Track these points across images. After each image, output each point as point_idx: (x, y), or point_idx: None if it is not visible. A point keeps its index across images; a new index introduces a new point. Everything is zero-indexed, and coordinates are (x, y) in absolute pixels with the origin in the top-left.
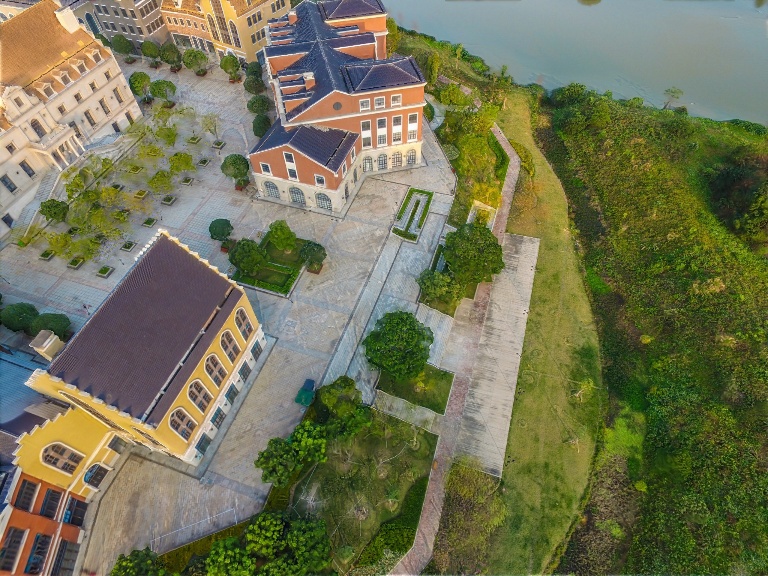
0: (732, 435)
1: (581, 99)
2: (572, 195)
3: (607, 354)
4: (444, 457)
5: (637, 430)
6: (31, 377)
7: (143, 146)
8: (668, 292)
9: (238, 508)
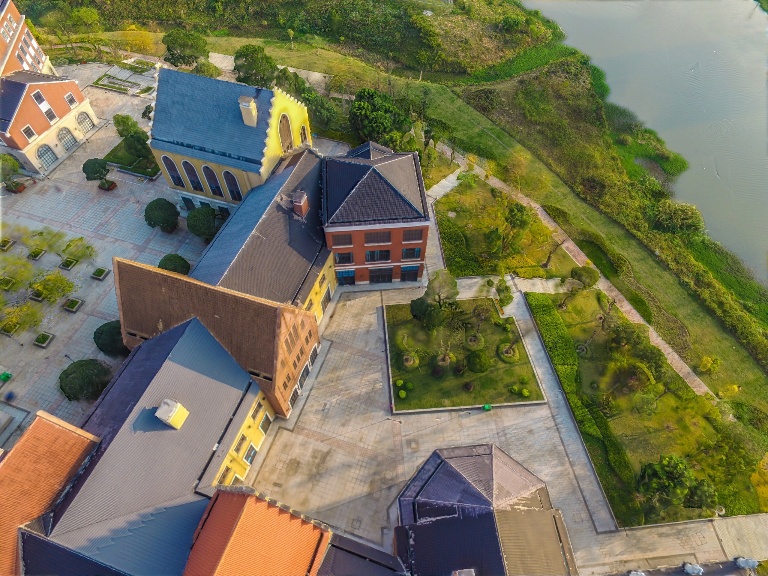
0: (323, 6)
1: (31, 2)
2: None
3: (270, 37)
4: (321, 92)
5: (314, 37)
6: (270, 120)
7: None
8: (237, 8)
9: (344, 153)
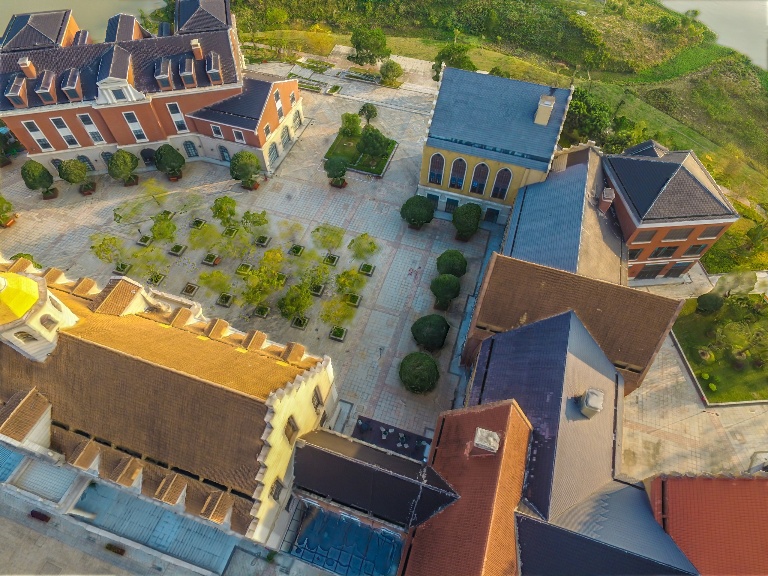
0: (474, 6)
1: None
2: (292, 29)
3: (426, 37)
4: None
5: (469, 36)
6: None
7: (192, 237)
8: (387, 8)
9: None
